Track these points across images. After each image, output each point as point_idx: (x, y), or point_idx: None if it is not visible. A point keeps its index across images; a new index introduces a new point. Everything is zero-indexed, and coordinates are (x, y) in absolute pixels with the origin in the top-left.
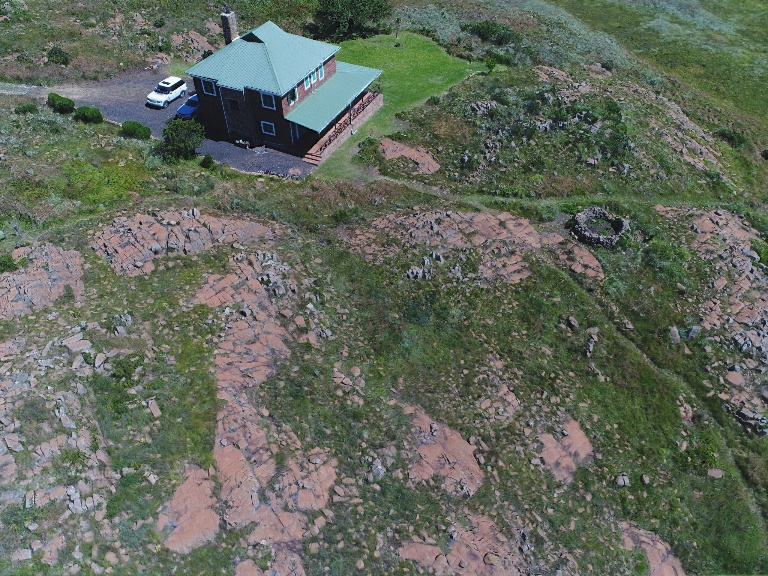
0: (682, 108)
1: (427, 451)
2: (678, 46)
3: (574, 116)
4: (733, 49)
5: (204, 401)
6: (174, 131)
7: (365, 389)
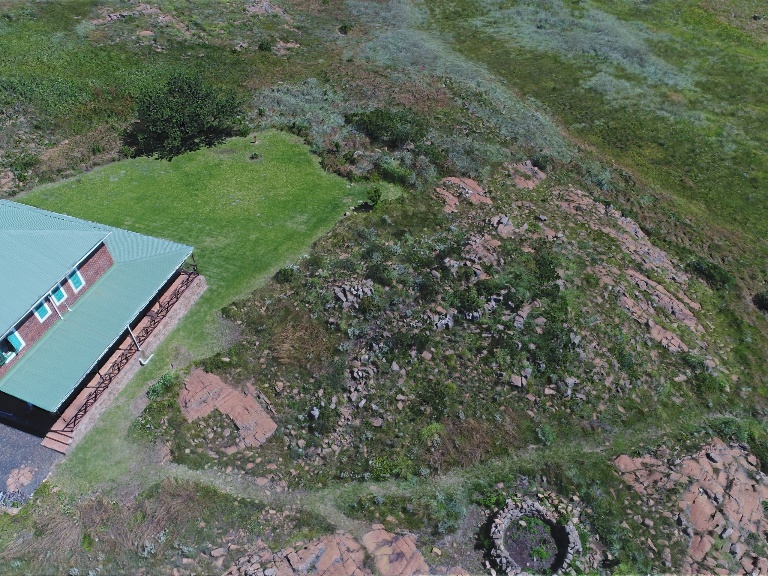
0: (640, 223)
1: None
2: (628, 114)
3: (489, 299)
4: (695, 115)
5: None
6: None
7: None
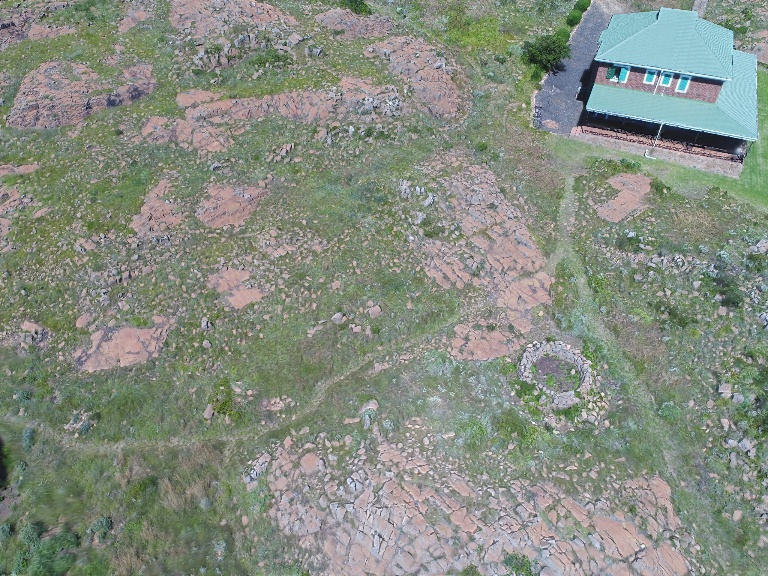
0: None
1: (227, 191)
2: None
3: None
4: None
5: (263, 91)
6: (543, 40)
7: (282, 164)
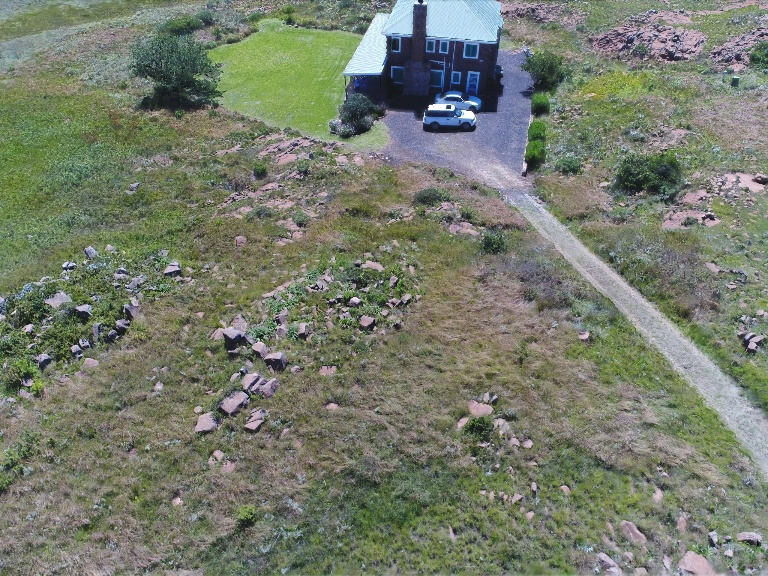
0: None
1: None
2: None
3: None
4: None
5: None
6: None
7: None
